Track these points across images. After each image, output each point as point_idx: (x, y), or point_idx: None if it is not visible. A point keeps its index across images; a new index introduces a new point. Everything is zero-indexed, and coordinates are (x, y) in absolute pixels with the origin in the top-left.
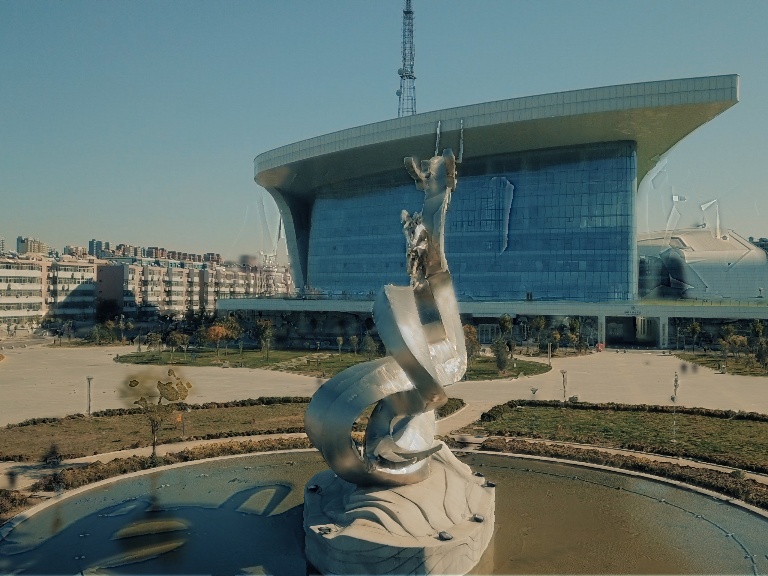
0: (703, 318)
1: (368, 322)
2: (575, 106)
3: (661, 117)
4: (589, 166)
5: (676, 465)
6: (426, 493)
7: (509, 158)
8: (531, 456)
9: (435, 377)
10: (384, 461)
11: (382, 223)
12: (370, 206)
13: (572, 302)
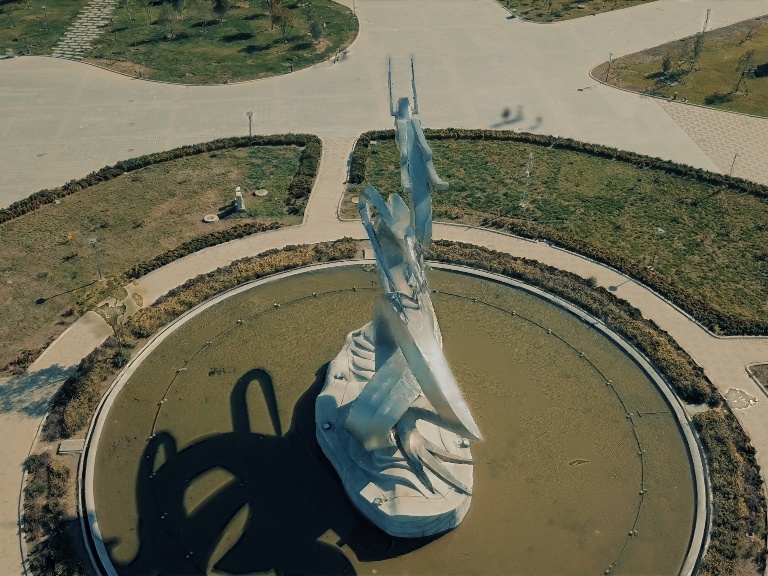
0: None
1: None
2: None
3: None
4: None
5: (543, 267)
6: (428, 434)
7: None
8: (428, 264)
9: None
10: (426, 466)
11: None
12: None
13: None
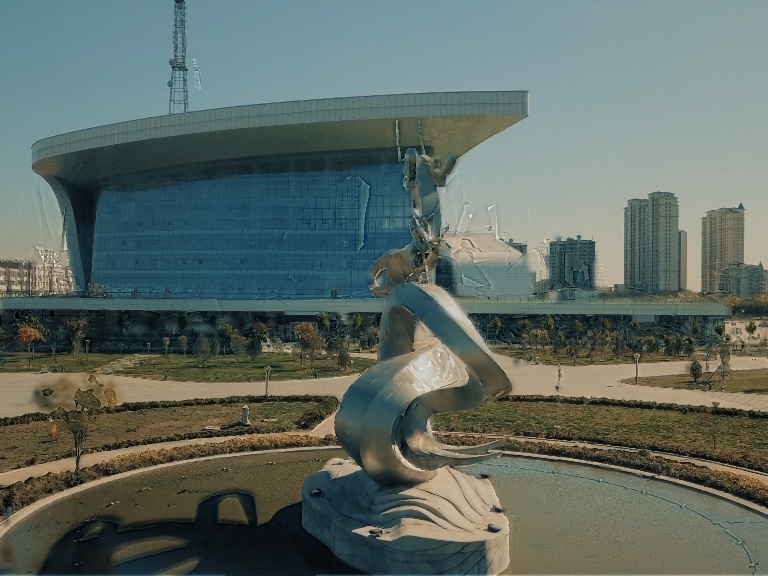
0: (498, 314)
1: (181, 321)
2: (383, 110)
3: (460, 126)
4: (390, 169)
5: (586, 448)
6: (446, 488)
7: (313, 157)
8: None
9: None
10: None
11: (178, 218)
12: (164, 200)
13: (381, 299)
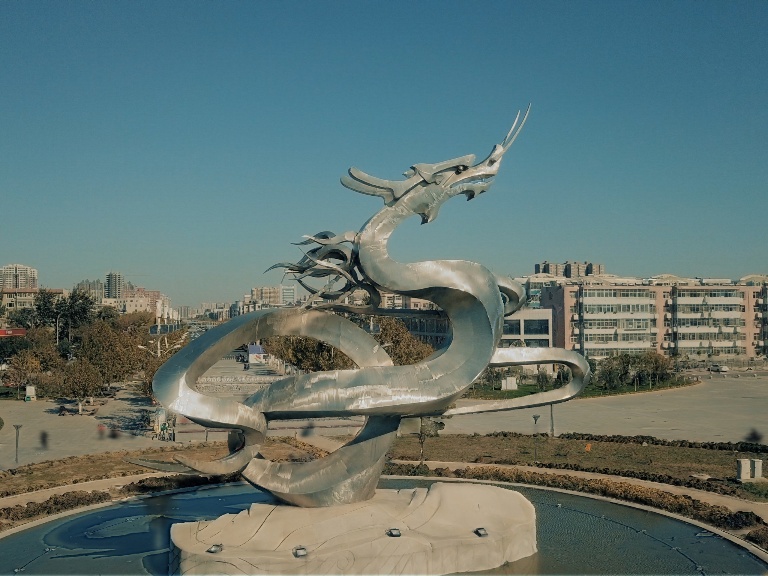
0: None
1: None
2: None
3: None
4: None
5: None
6: (296, 517)
7: None
8: None
9: (163, 391)
10: None
11: None
12: None
13: None
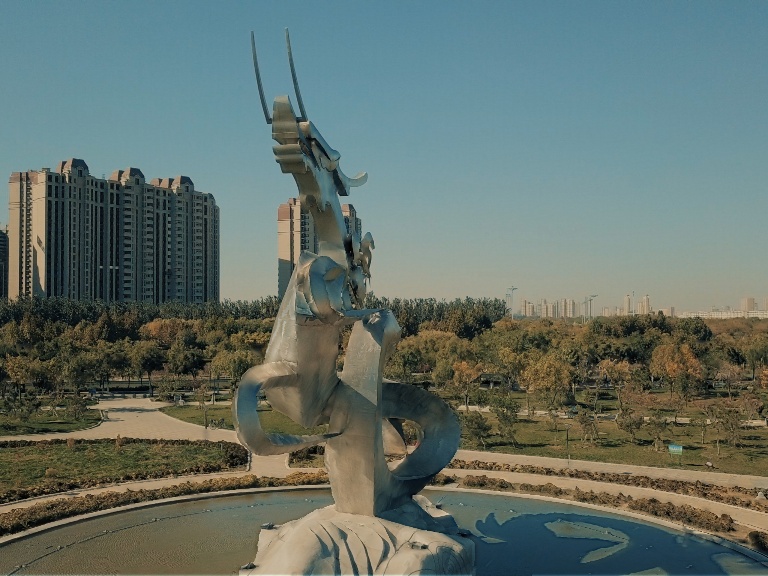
0: None
1: None
2: None
3: None
4: None
5: None
6: None
7: None
8: None
9: None
10: None
11: None
12: None
13: None
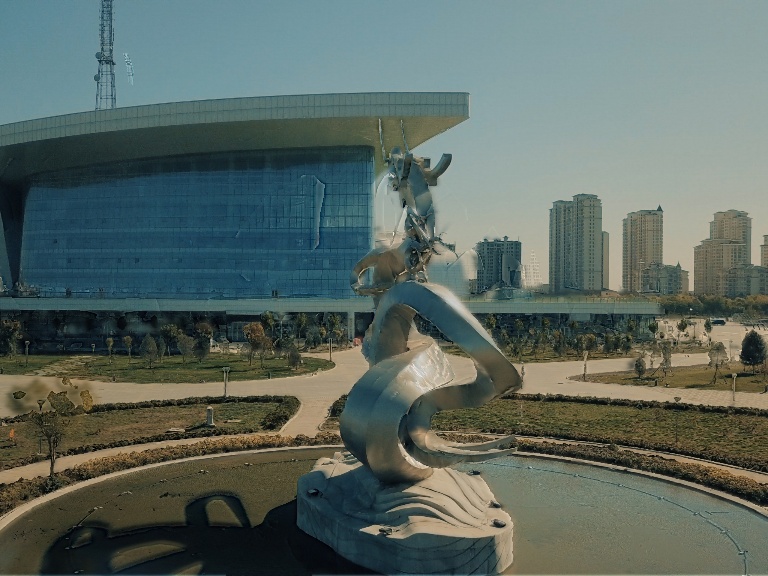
0: None
1: (121, 321)
2: (325, 109)
3: None
4: (331, 168)
5: (555, 444)
6: (446, 485)
7: (253, 155)
8: None
9: None
10: None
11: (112, 216)
12: (98, 197)
13: (324, 299)
